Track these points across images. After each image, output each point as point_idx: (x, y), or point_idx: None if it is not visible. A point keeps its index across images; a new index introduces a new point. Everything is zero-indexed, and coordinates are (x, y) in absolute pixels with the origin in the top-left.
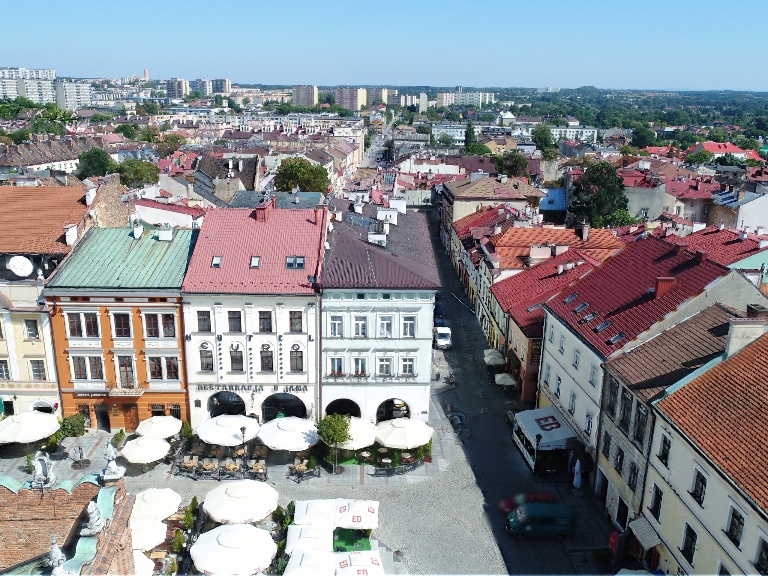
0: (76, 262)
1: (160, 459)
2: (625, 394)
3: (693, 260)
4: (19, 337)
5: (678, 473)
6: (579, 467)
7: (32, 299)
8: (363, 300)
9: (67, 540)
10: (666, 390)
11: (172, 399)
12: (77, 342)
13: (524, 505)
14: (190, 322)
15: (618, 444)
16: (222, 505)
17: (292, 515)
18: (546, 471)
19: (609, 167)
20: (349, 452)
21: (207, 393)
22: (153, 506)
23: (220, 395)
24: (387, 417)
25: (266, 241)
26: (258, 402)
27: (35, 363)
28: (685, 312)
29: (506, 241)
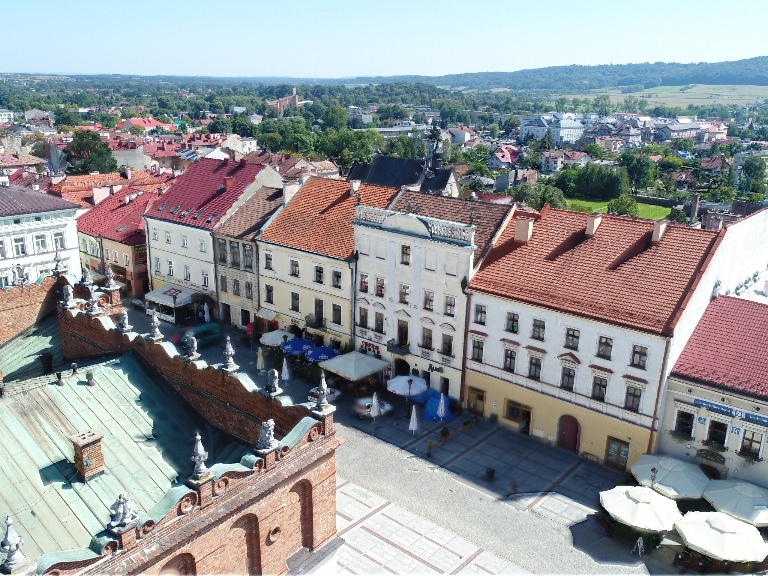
0: None
1: None
2: (232, 245)
3: (240, 165)
4: None
5: (280, 269)
6: (207, 307)
7: None
8: (19, 224)
9: (38, 318)
10: (261, 229)
11: None
12: None
13: (190, 330)
14: None
15: (233, 278)
16: None
17: None
18: (185, 319)
19: (94, 134)
20: None
21: None
22: None
23: None
24: None
25: None
26: None
27: None
28: (249, 193)
29: (68, 188)
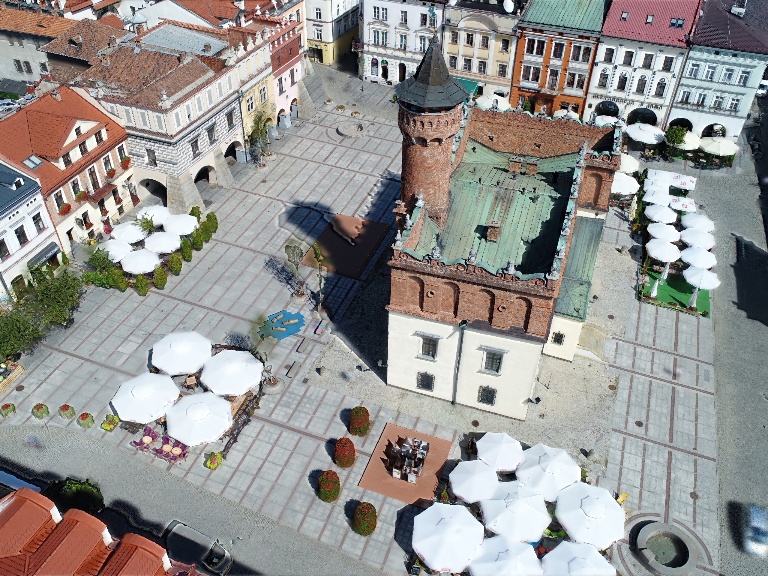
0: (535, 5)
1: None
2: None
3: None
4: (497, 49)
5: None
6: None
7: (510, 27)
8: (718, 56)
9: (593, 147)
10: None
11: (575, 101)
12: (529, 57)
13: None
14: (600, 54)
15: None
16: None
17: (646, 175)
18: None
19: None
20: (679, 152)
21: (598, 100)
22: None
23: (604, 103)
24: (708, 136)
25: (659, 5)
26: (628, 111)
27: (501, 66)
28: None
29: None
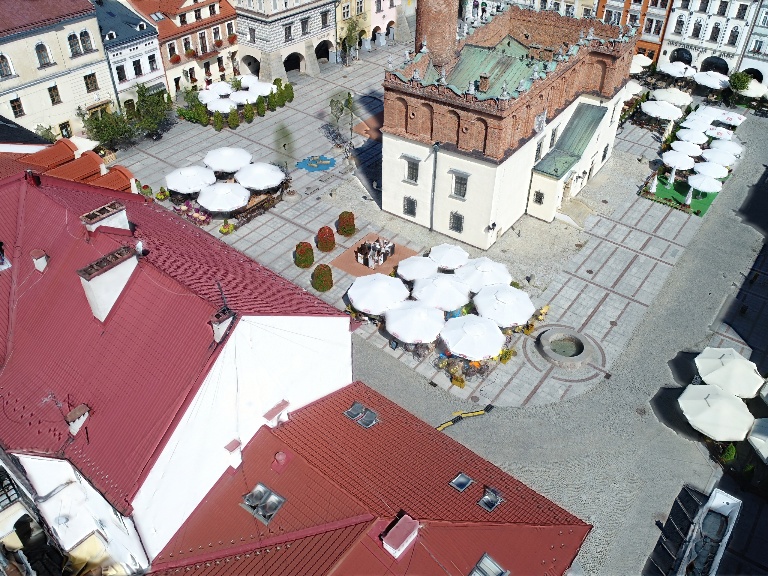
0: None
1: (636, 73)
2: None
3: None
4: None
5: None
6: None
7: None
8: None
9: None
10: None
11: (652, 47)
12: (612, 2)
13: None
14: (678, 0)
15: None
16: (662, 94)
17: None
18: None
19: None
20: (745, 101)
21: (673, 47)
22: (629, 87)
23: (680, 51)
24: None
25: None
26: (701, 59)
27: (586, 10)
28: None
29: None
